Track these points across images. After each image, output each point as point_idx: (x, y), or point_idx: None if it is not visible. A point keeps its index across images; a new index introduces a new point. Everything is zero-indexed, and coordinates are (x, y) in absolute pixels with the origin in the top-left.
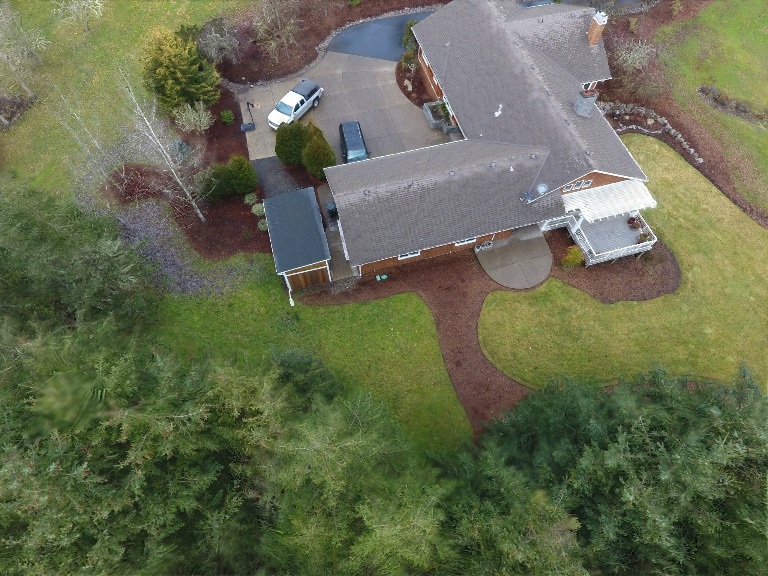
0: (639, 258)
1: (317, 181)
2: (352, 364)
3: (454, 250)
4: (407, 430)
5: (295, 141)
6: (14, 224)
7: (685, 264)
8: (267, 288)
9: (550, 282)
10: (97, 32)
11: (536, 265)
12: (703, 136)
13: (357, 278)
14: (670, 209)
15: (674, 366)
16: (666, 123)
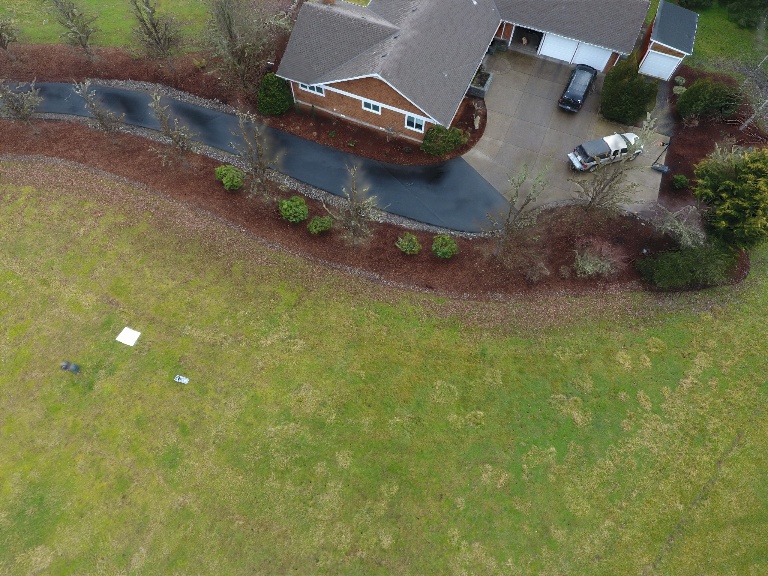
0: None
1: None
2: (653, 1)
3: None
4: None
5: None
6: None
7: None
8: None
9: None
10: None
11: None
12: (276, 0)
13: None
14: None
15: None
16: None
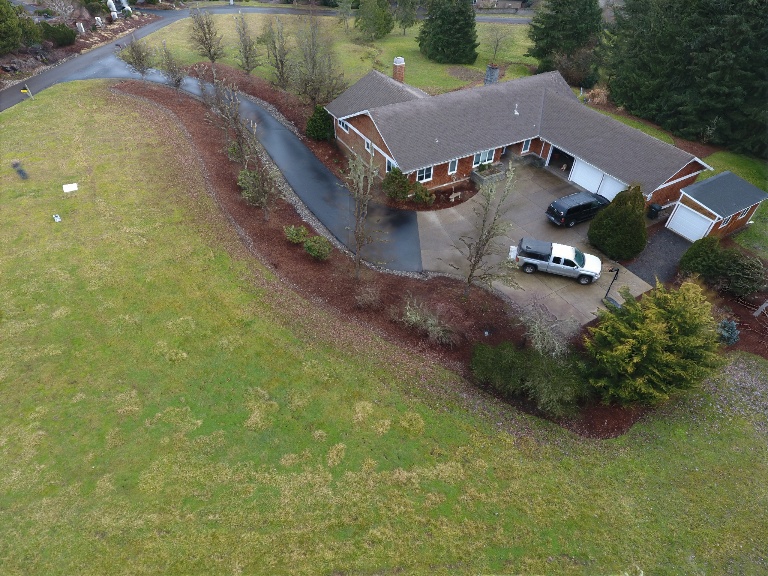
0: None
1: None
2: None
3: None
4: (753, 169)
5: None
6: None
7: None
8: (762, 235)
9: None
10: None
11: None
12: None
13: None
14: None
15: None
16: None
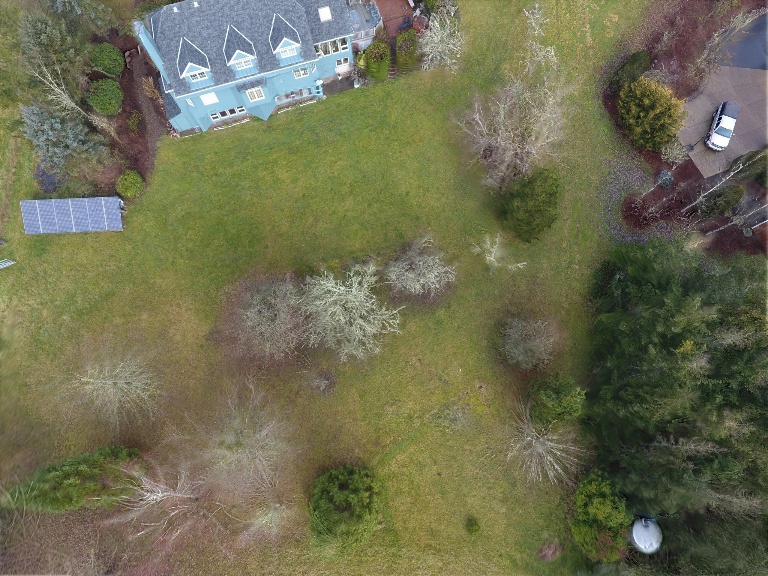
0: None
1: (765, 191)
2: None
3: None
4: None
5: (762, 165)
6: (760, 278)
7: None
8: None
9: None
10: (537, 72)
11: None
12: None
13: None
14: None
15: None
16: None
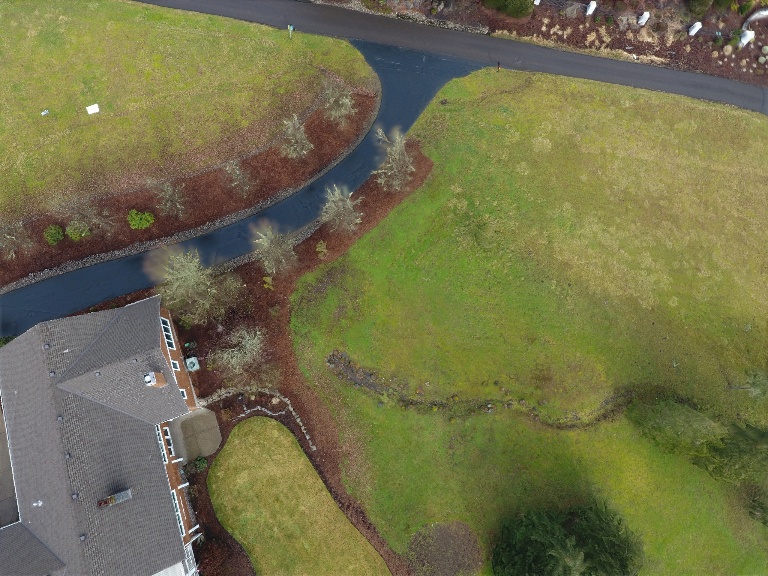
0: None
1: None
2: None
3: None
4: None
5: None
6: None
7: None
8: None
9: None
10: None
11: None
12: (322, 418)
13: None
14: (267, 517)
15: None
16: (288, 404)
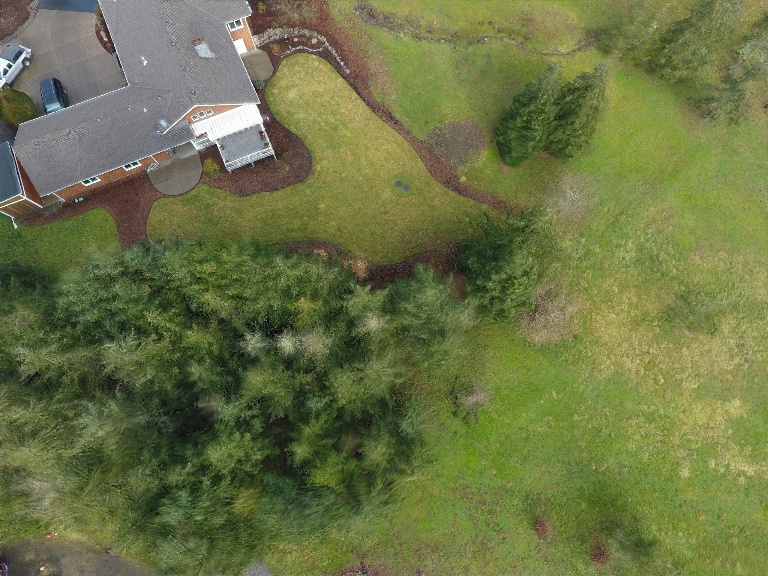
0: (280, 159)
1: None
2: (59, 261)
3: (130, 173)
4: None
5: None
6: None
7: (317, 159)
8: None
9: (199, 187)
10: None
11: (190, 176)
12: (352, 50)
13: (62, 203)
14: (315, 116)
15: (288, 233)
16: (325, 41)
